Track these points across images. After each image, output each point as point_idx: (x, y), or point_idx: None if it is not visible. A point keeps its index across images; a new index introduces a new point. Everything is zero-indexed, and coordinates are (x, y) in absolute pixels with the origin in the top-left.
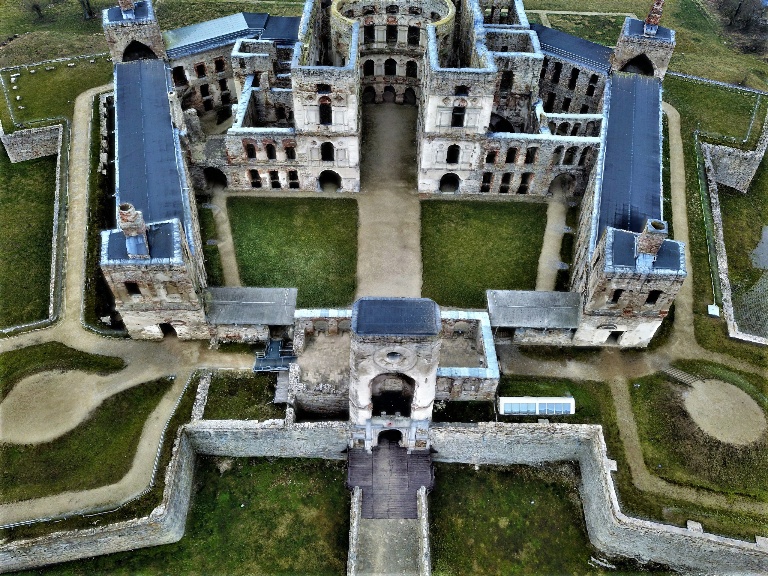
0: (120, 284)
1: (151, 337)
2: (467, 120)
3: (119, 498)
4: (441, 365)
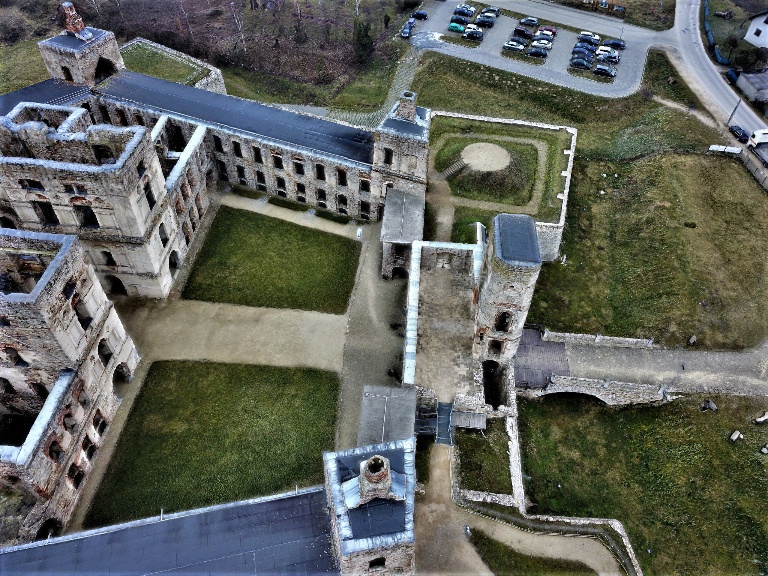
0: None
1: None
2: (155, 193)
3: (613, 568)
4: (447, 292)
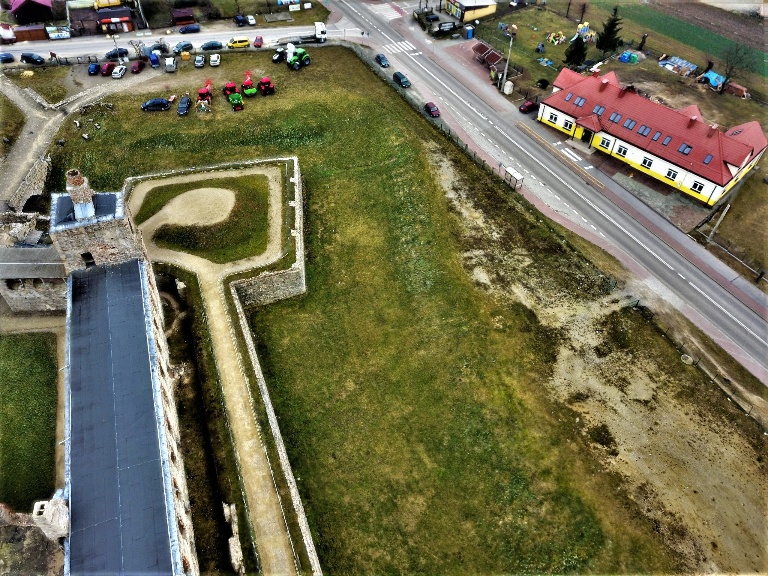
0: None
1: None
2: None
3: (153, 182)
4: None
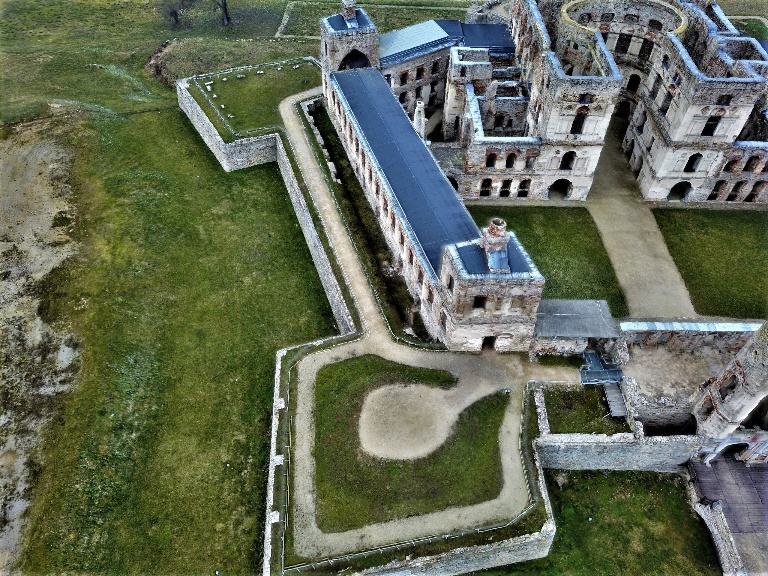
0: (470, 298)
1: (469, 350)
2: (719, 129)
3: (505, 513)
4: None
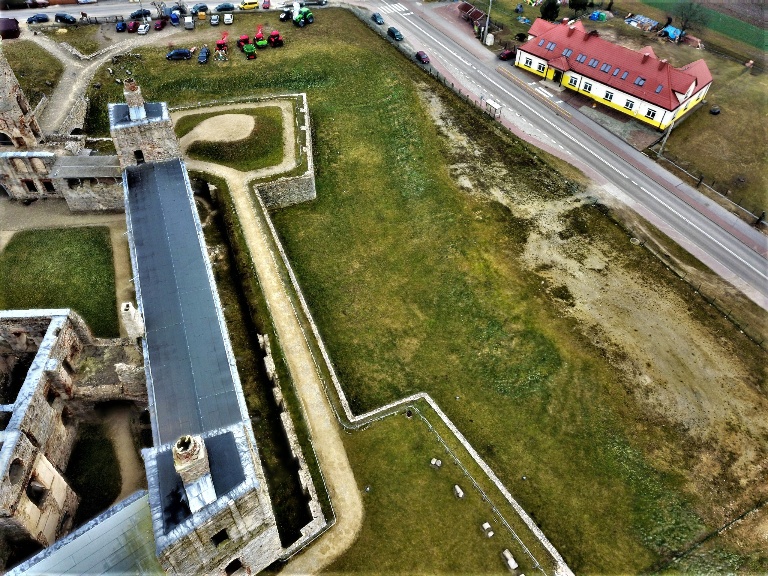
0: None
1: None
2: None
3: (182, 112)
4: None
